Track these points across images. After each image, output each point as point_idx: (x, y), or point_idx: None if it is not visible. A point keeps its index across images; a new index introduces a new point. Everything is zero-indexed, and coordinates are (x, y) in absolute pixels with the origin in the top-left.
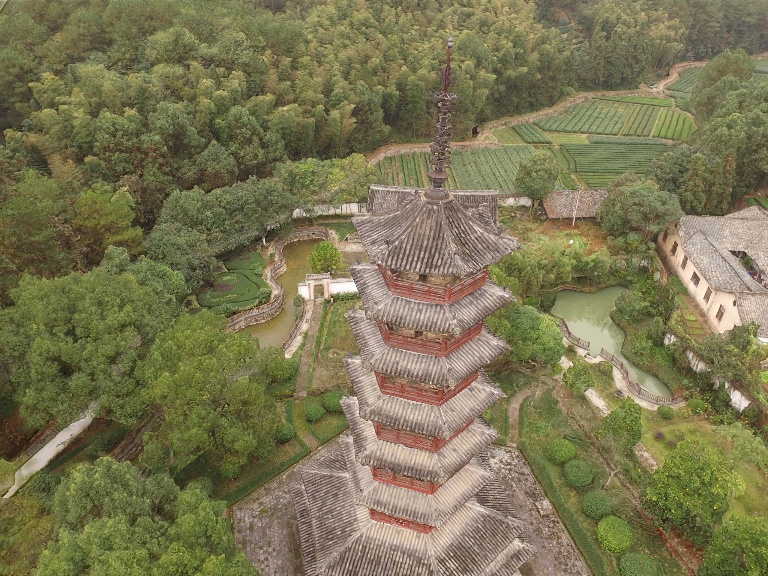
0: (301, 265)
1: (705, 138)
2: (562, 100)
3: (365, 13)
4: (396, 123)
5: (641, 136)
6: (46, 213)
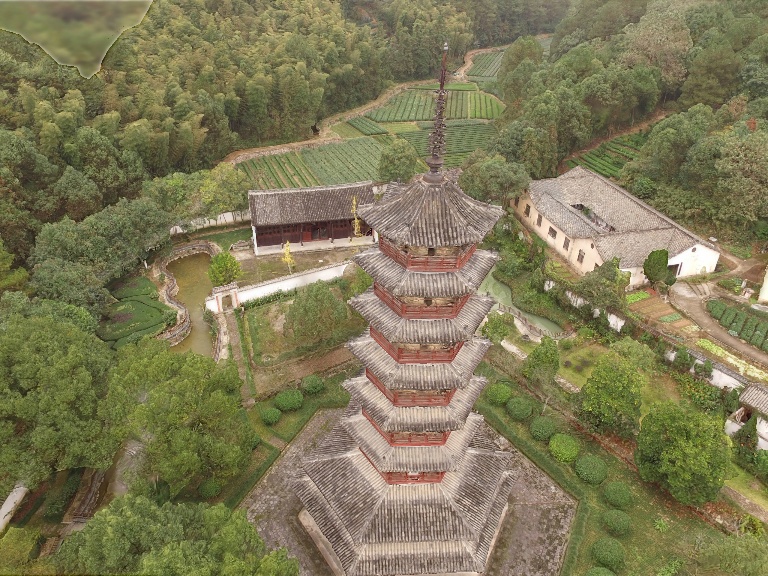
0: (192, 282)
1: (528, 114)
2: (383, 92)
3: (183, 20)
4: (239, 129)
5: (461, 118)
6: None
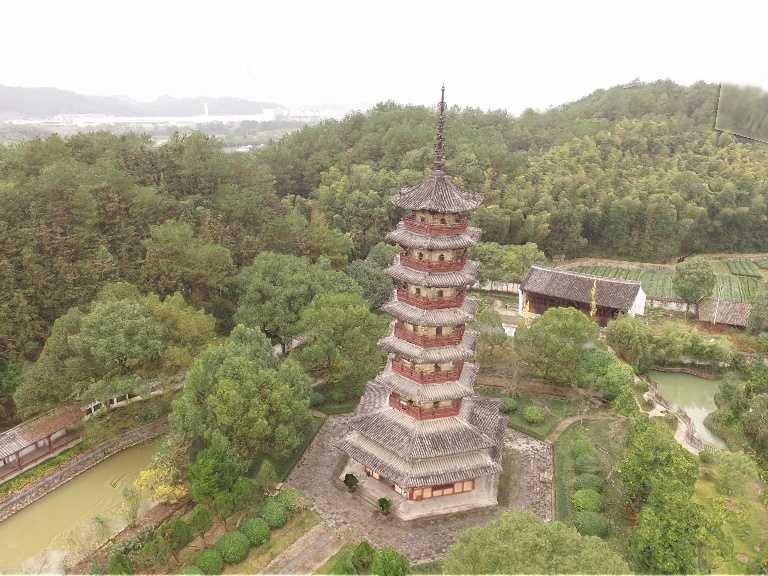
0: None
1: None
2: None
3: (592, 152)
4: (599, 240)
5: None
6: (294, 233)
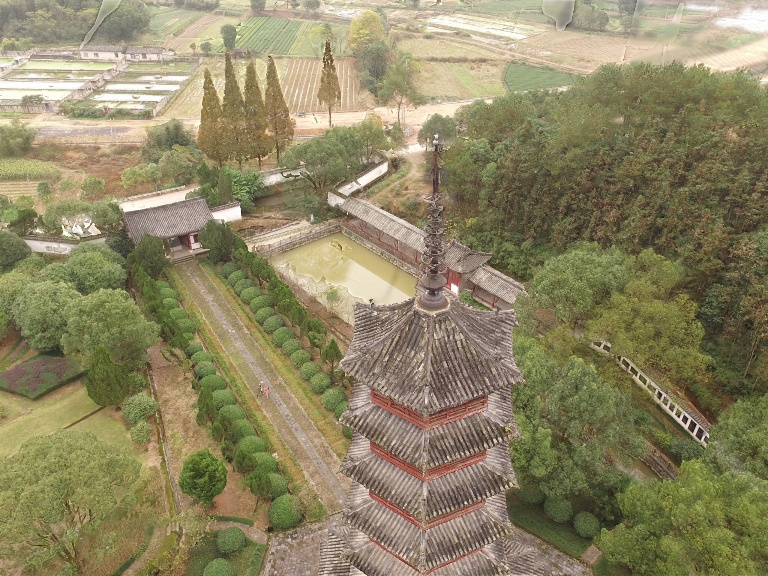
0: None
1: None
2: None
3: None
4: None
5: None
6: None
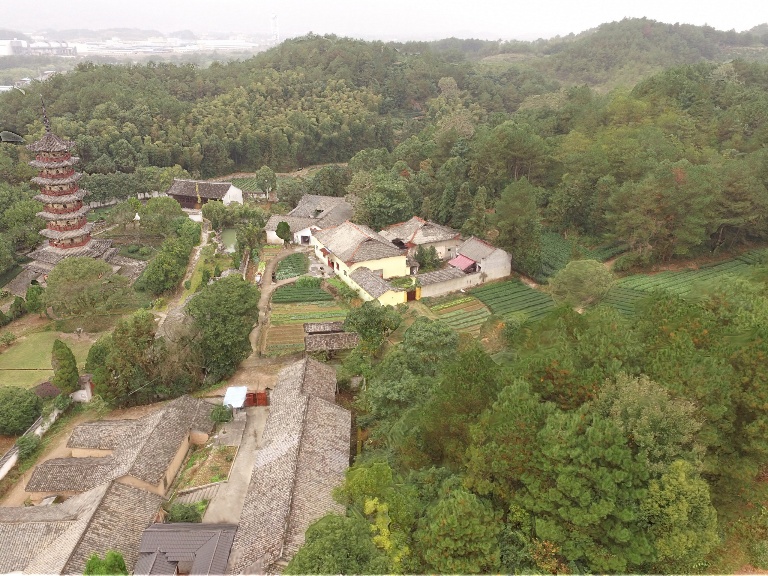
0: None
1: None
2: None
3: (243, 99)
4: (246, 161)
5: None
6: (3, 169)
